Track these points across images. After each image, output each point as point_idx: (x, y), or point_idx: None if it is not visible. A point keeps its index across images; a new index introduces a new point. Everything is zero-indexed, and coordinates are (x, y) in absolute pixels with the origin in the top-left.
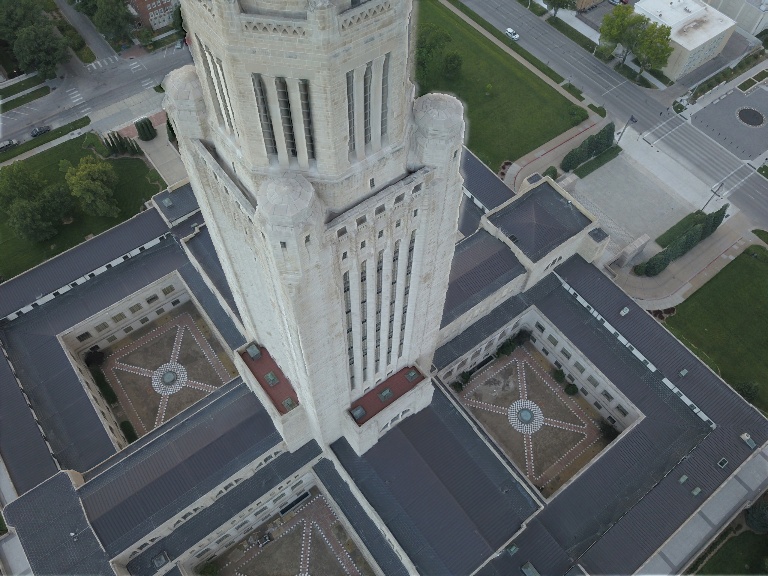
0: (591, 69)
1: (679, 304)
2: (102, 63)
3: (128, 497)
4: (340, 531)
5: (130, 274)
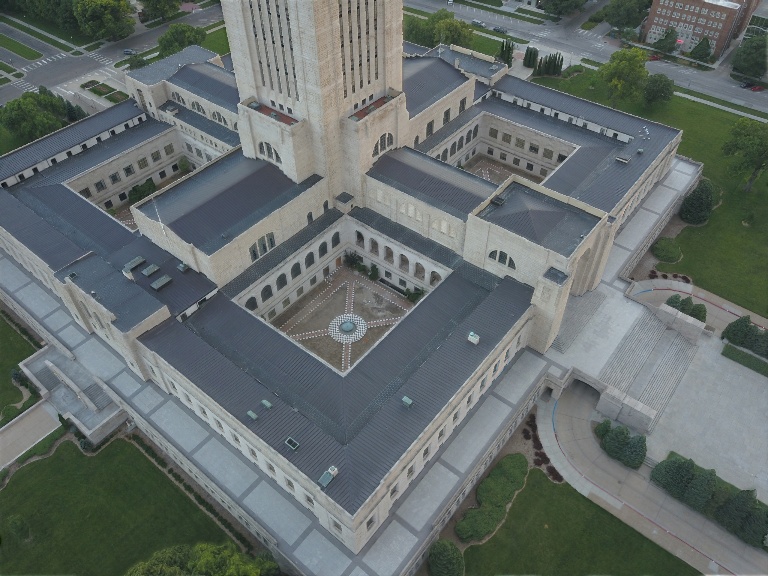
0: None
1: (574, 488)
2: (588, 33)
3: (201, 73)
4: None
5: None
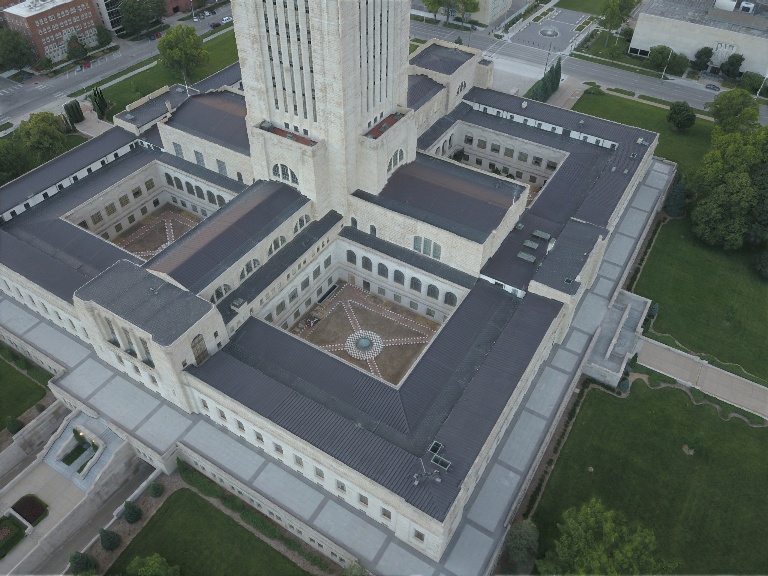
0: (427, 29)
1: None
2: (8, 90)
3: (194, 253)
4: (375, 299)
5: (112, 173)
